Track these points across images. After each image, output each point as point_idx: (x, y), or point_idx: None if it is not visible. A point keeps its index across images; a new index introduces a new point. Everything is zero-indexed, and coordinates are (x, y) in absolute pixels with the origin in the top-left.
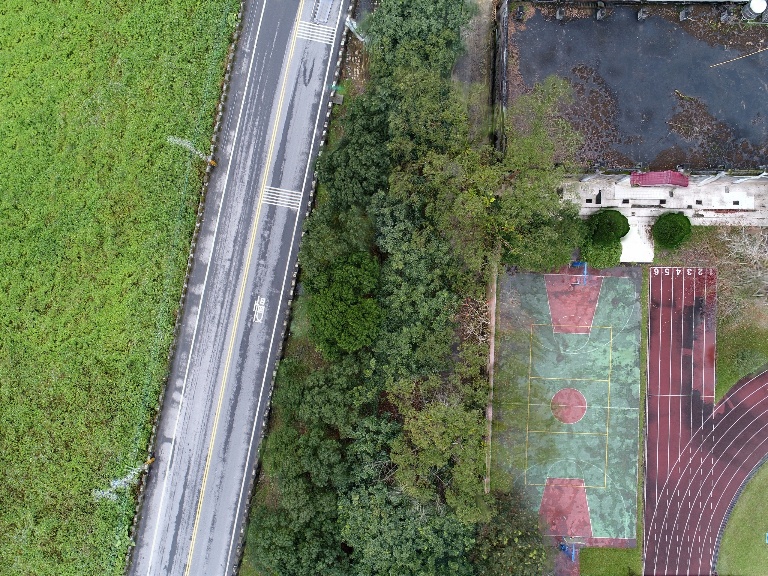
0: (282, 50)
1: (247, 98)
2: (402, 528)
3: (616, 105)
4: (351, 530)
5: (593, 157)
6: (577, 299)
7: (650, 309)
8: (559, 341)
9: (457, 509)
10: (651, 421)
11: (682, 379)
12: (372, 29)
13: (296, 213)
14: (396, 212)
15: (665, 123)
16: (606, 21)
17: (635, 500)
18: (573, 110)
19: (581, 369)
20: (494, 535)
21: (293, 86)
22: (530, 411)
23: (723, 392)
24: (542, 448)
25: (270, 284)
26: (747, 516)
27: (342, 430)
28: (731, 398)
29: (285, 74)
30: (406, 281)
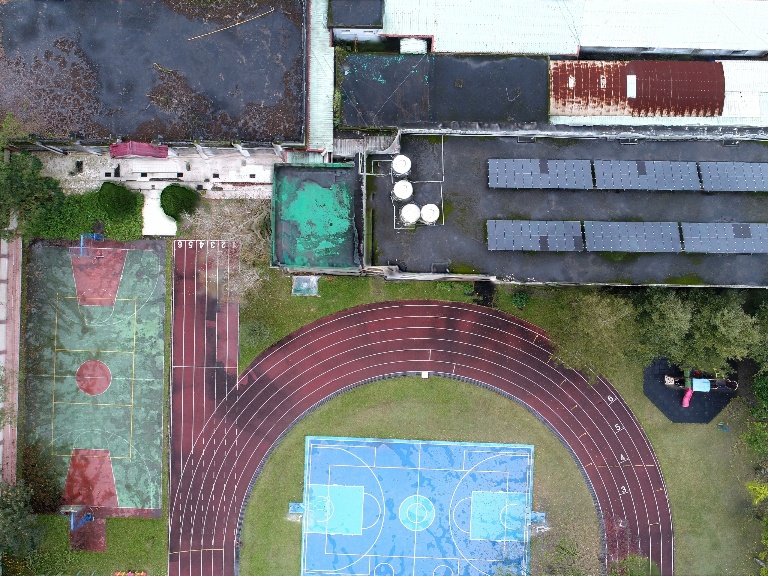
0: None
1: None
2: None
3: (97, 78)
4: None
5: (75, 129)
6: (101, 272)
7: (174, 282)
8: (84, 313)
9: None
10: (175, 392)
11: (206, 351)
12: None
13: None
14: None
15: (145, 95)
16: None
17: (160, 470)
18: (55, 83)
19: (106, 341)
20: None
21: None
22: (56, 383)
23: (246, 363)
24: (68, 419)
25: None
26: (270, 486)
27: None
28: (254, 369)
29: None
30: None
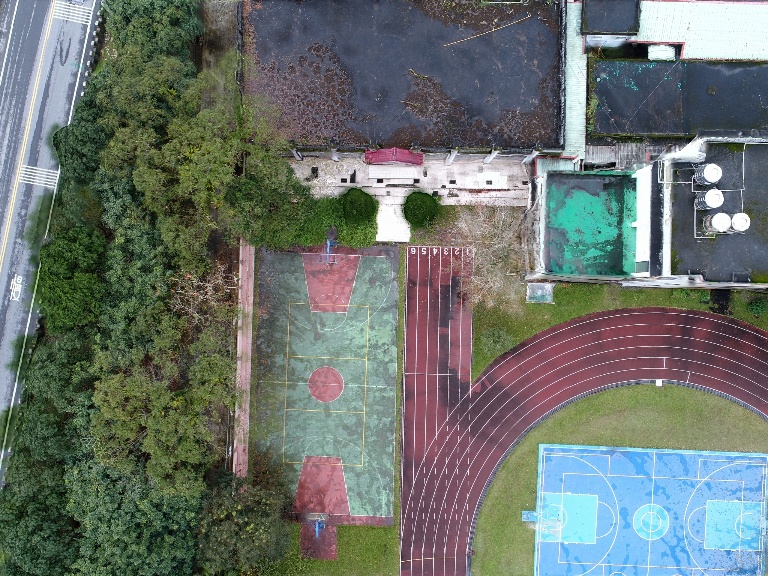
0: (38, 30)
1: (4, 78)
2: (120, 502)
3: (352, 84)
4: (75, 504)
5: (329, 135)
6: (334, 278)
7: (407, 288)
8: (316, 320)
9: (176, 483)
10: (408, 399)
11: (439, 358)
12: (110, 8)
13: (53, 192)
14: (115, 188)
15: (400, 101)
16: (342, 0)
17: (392, 478)
18: (309, 88)
19: (338, 348)
20: (216, 509)
21: (49, 66)
22: (288, 389)
23: (479, 371)
24: (300, 426)
25: (27, 262)
26: (503, 494)
27: (56, 404)
28: (487, 377)
29: (41, 54)
30: (128, 257)
